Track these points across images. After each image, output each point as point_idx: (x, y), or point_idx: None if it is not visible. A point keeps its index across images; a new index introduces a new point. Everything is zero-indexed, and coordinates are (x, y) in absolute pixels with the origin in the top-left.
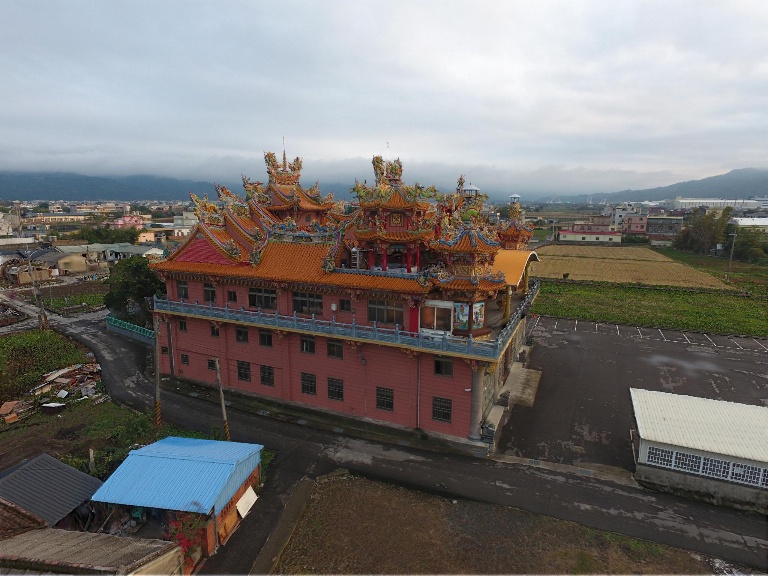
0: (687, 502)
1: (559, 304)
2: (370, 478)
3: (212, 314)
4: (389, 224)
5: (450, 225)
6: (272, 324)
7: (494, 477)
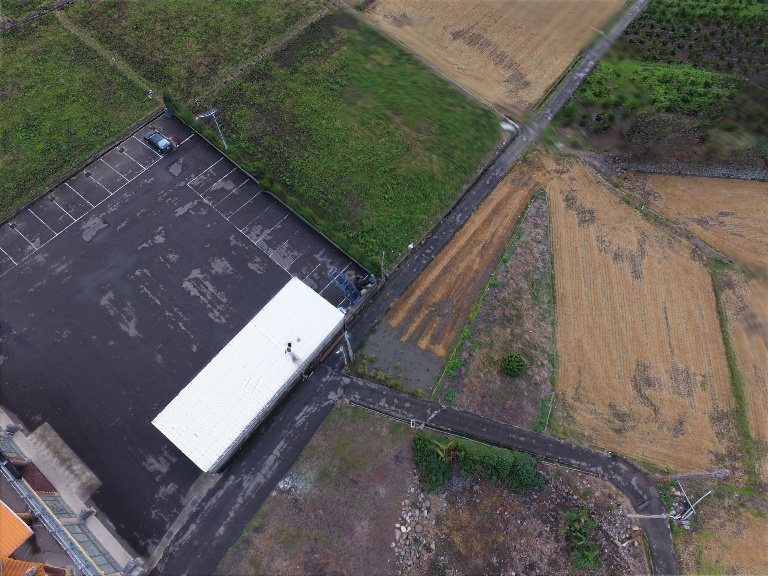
0: (243, 458)
1: None
2: None
3: None
4: None
5: None
6: None
7: None
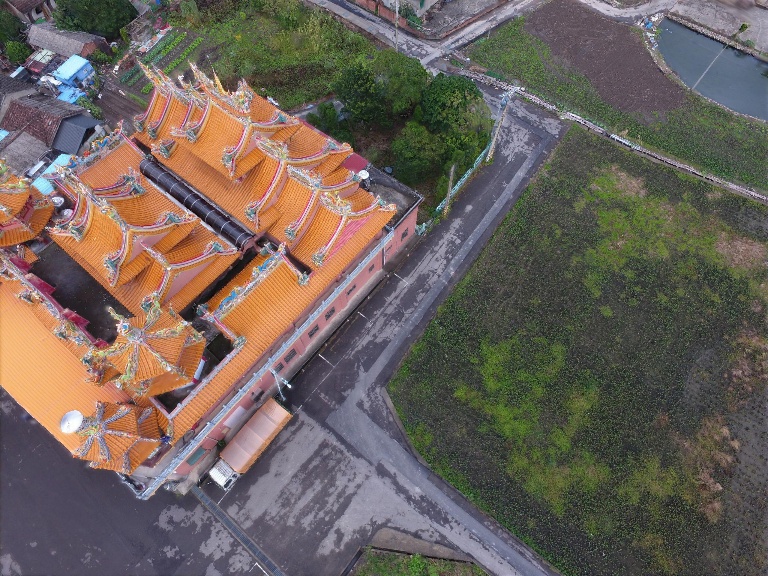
0: None
1: None
2: None
3: None
4: None
5: None
6: None
7: None
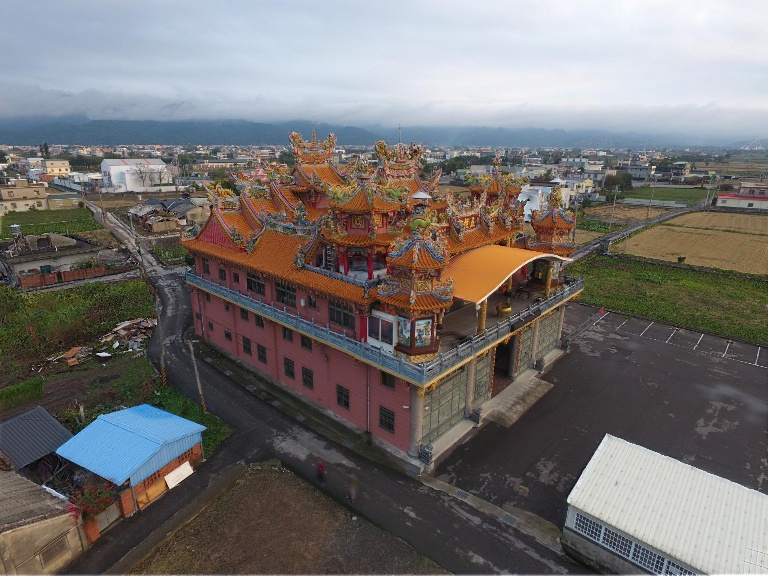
0: None
1: (645, 298)
2: (296, 474)
3: (220, 292)
4: (350, 226)
5: (439, 223)
6: (258, 310)
7: (407, 502)
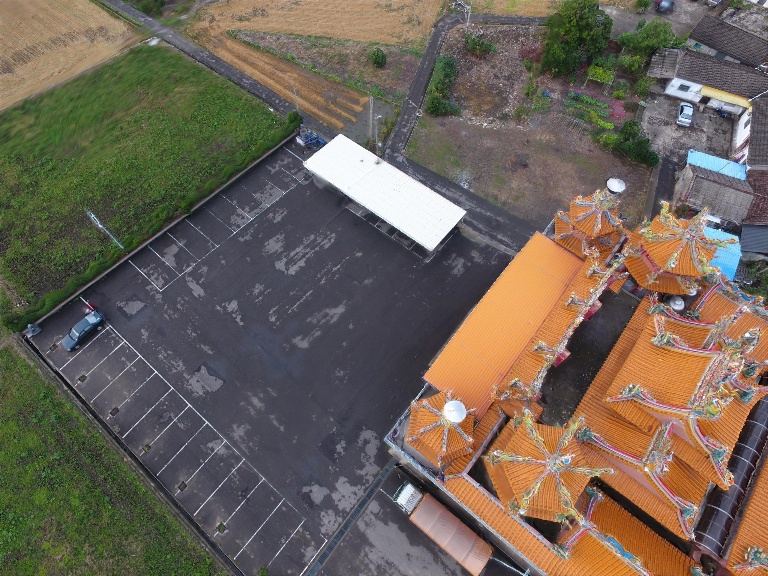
0: None
1: None
2: None
3: None
4: None
5: None
6: None
7: None
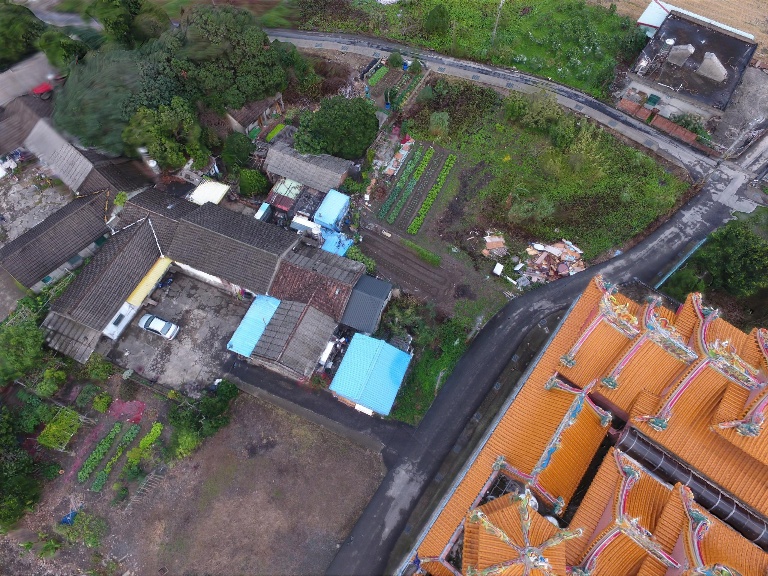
0: None
1: None
2: None
3: None
4: None
5: None
6: None
7: None
